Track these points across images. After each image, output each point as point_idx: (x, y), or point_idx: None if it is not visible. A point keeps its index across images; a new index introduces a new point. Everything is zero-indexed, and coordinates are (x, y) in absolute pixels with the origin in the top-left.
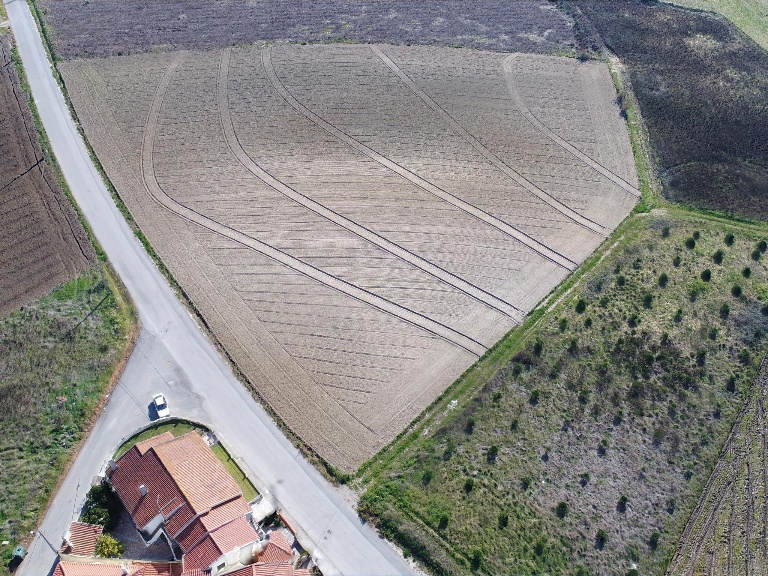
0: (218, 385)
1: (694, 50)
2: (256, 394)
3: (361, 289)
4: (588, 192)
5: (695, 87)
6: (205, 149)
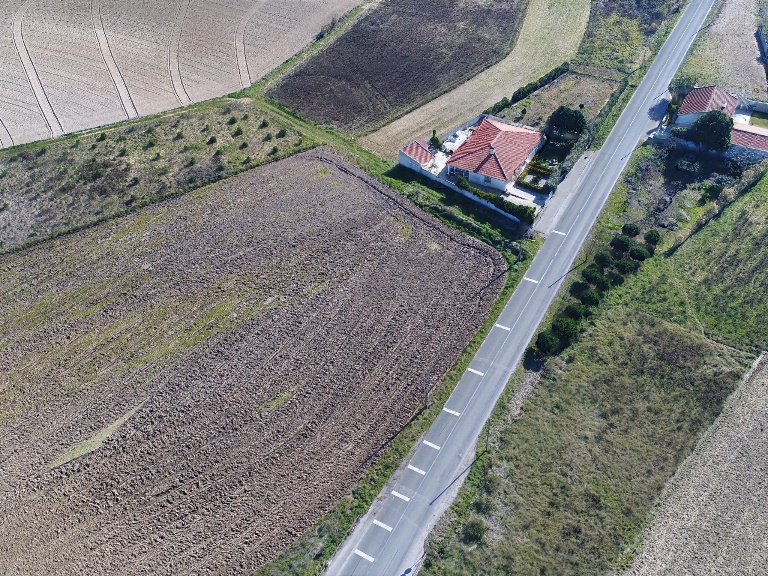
0: None
1: (460, 4)
2: None
3: None
4: (211, 77)
5: (413, 29)
6: (5, 6)
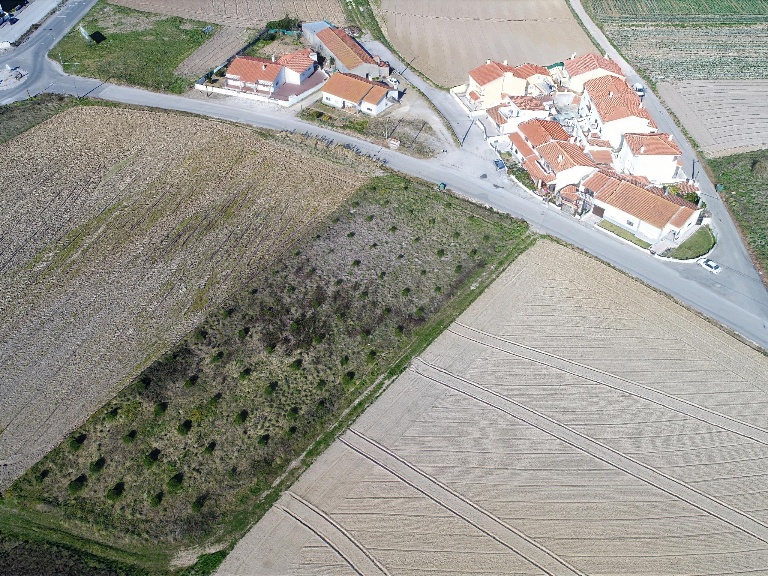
0: (678, 286)
1: None
2: (641, 282)
3: (595, 381)
4: None
5: None
6: None
